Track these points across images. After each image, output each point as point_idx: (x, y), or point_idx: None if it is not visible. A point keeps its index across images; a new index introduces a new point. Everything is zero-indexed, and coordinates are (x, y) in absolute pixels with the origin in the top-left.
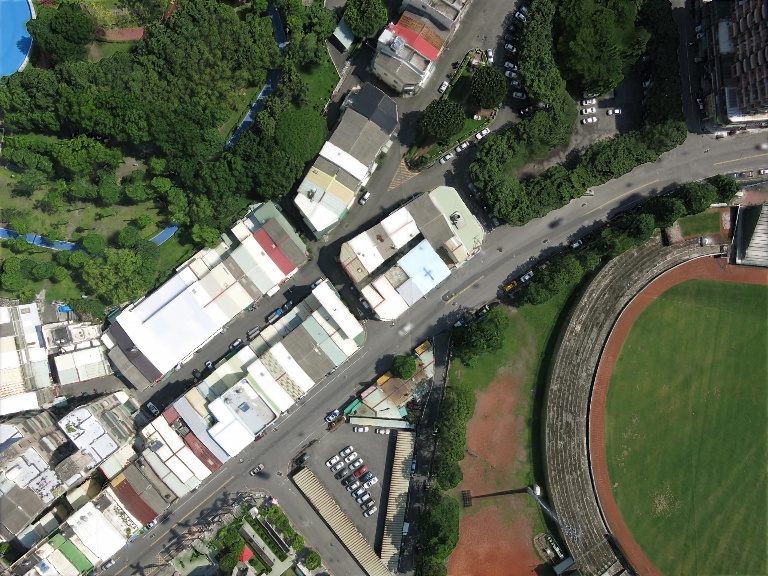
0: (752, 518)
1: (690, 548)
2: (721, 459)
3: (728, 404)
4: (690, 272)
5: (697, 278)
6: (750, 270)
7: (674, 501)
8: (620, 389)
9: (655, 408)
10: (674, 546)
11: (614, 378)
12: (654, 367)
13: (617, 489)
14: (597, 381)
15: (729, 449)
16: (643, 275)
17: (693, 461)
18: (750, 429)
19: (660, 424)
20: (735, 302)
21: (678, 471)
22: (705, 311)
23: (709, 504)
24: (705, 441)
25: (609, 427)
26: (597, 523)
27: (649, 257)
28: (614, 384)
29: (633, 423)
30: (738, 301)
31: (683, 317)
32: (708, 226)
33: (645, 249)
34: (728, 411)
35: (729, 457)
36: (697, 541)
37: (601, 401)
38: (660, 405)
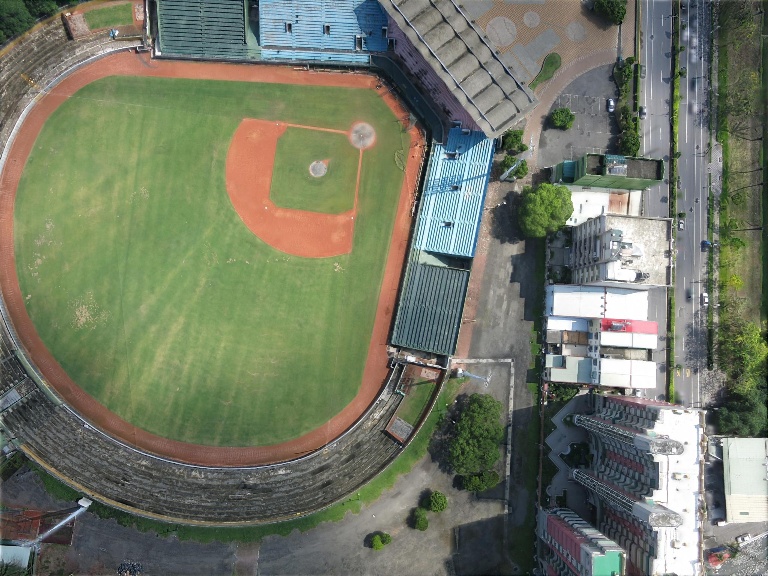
0: (193, 327)
1: (120, 363)
2: (153, 264)
3: (158, 204)
4: (109, 69)
5: (117, 74)
6: (177, 64)
7: (99, 312)
8: (31, 193)
9: (73, 212)
10: (101, 362)
11: (23, 182)
12: (70, 168)
13: (30, 301)
14: (3, 186)
15: (162, 253)
16: (48, 71)
17: (120, 267)
18: (186, 230)
19: (79, 229)
20: (161, 97)
21: (102, 279)
22: (127, 108)
23: (141, 313)
24: (133, 245)
25: (19, 234)
26: (1, 337)
27: (53, 52)
28: (23, 188)
29: (47, 229)
30: (165, 96)
31: (102, 115)
32: (119, 18)
33: (47, 43)
34: (159, 212)
35: (162, 261)
36: (128, 355)
37: (9, 207)
38: (78, 208)
